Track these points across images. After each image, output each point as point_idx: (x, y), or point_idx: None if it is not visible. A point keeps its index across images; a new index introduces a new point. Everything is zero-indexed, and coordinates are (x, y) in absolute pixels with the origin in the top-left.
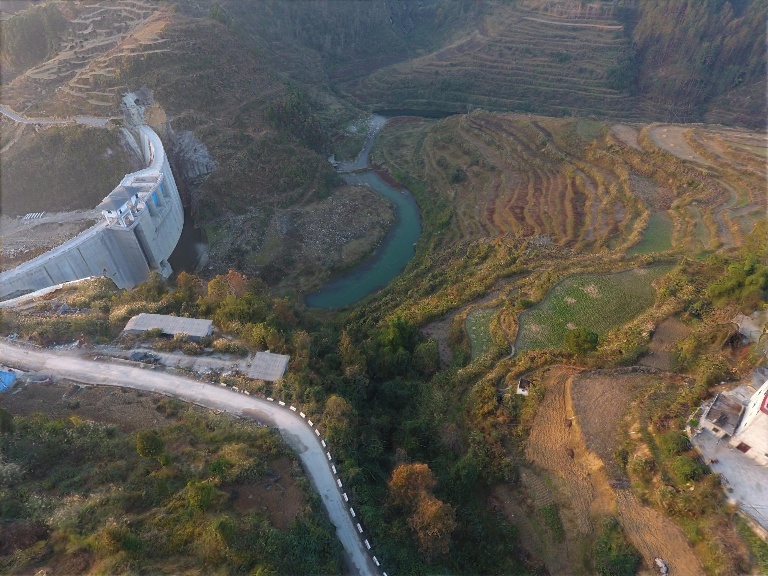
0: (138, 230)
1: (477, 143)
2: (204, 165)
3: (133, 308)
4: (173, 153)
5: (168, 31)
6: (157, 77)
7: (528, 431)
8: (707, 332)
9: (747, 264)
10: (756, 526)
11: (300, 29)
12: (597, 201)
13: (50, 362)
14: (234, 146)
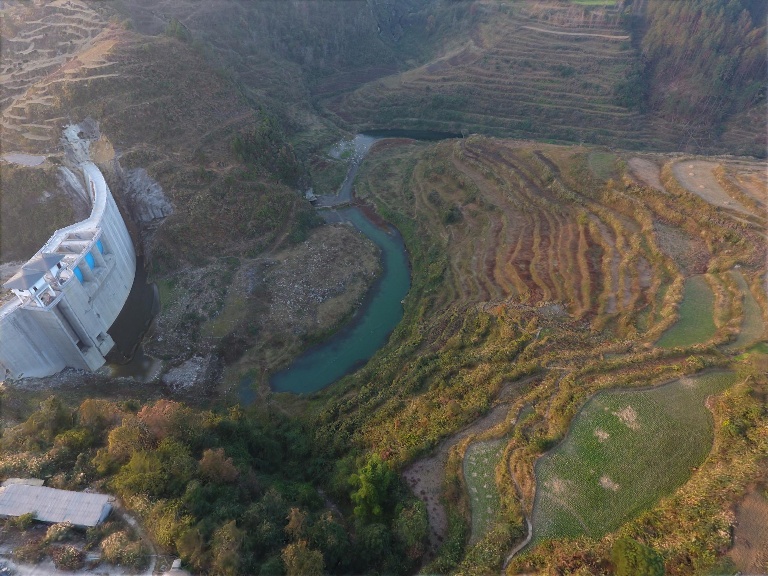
0: (62, 306)
1: (473, 175)
2: (159, 208)
3: (7, 466)
4: (124, 193)
5: (116, 52)
6: (103, 106)
7: None
8: None
9: None
10: None
11: (278, 41)
12: (616, 256)
13: None
14: (194, 185)
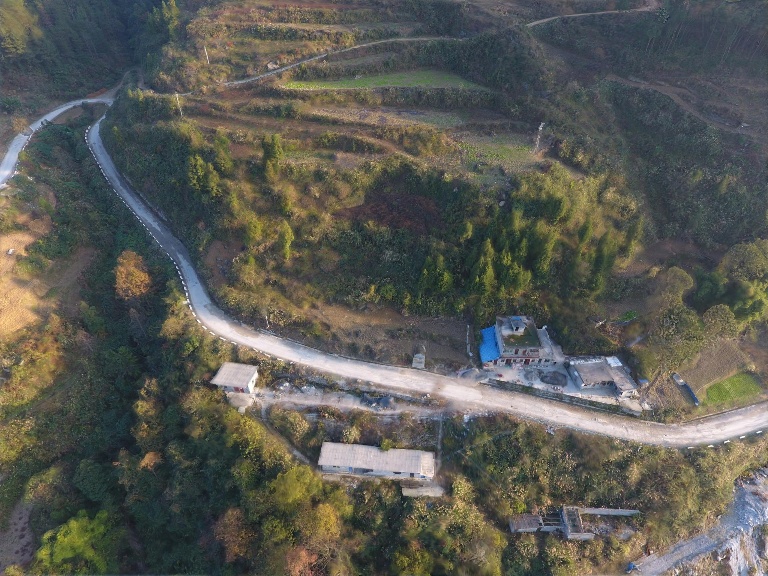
0: None
1: None
2: None
3: None
4: None
5: None
6: None
7: None
8: None
9: None
10: None
11: None
12: None
13: (476, 395)
14: None
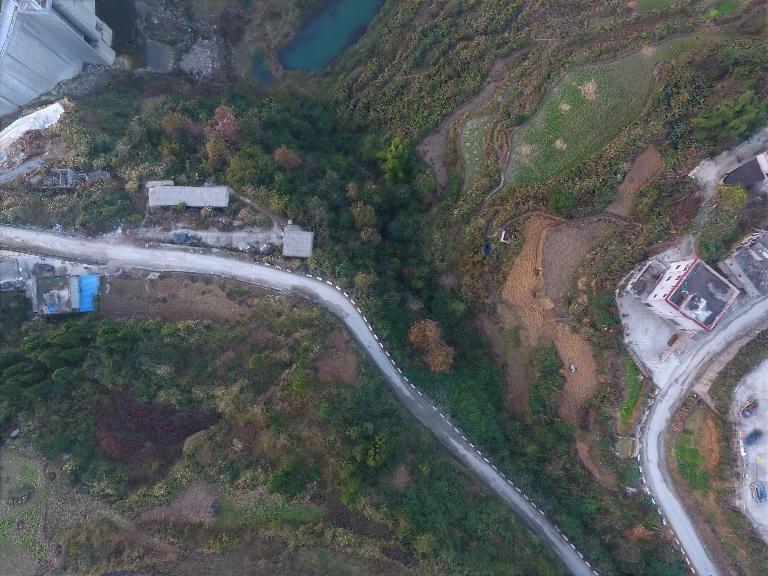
0: (55, 4)
1: None
2: None
3: (141, 174)
4: None
5: None
6: None
7: (506, 277)
8: (670, 184)
9: (741, 102)
10: (634, 355)
11: None
12: None
13: (110, 252)
14: None
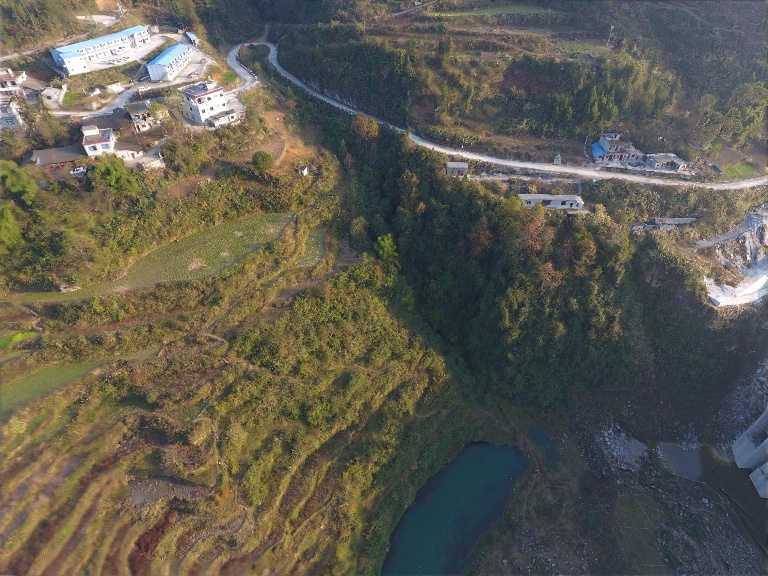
0: None
1: None
2: None
3: None
4: None
5: None
6: None
7: None
8: None
9: (105, 166)
10: None
11: None
12: None
13: (596, 173)
14: None
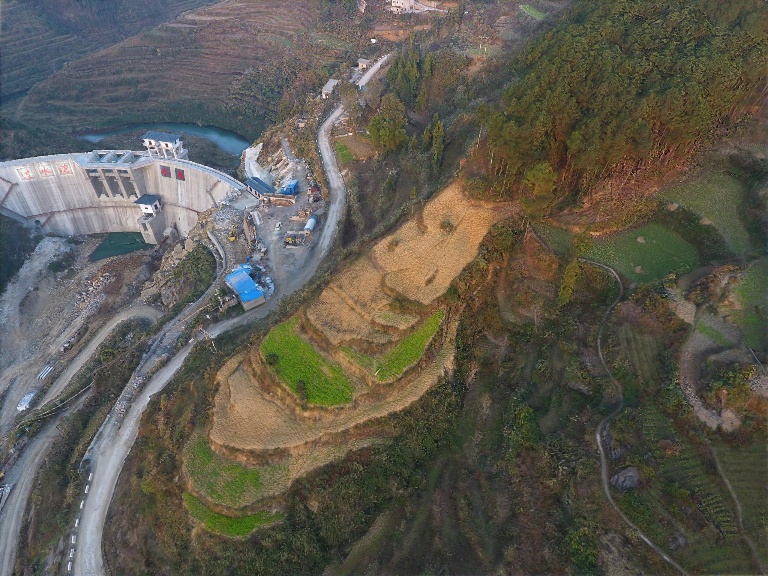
0: None
1: None
2: None
3: None
4: None
5: None
6: None
7: None
8: (366, 11)
9: None
10: None
11: None
12: None
13: None
14: (26, 149)
